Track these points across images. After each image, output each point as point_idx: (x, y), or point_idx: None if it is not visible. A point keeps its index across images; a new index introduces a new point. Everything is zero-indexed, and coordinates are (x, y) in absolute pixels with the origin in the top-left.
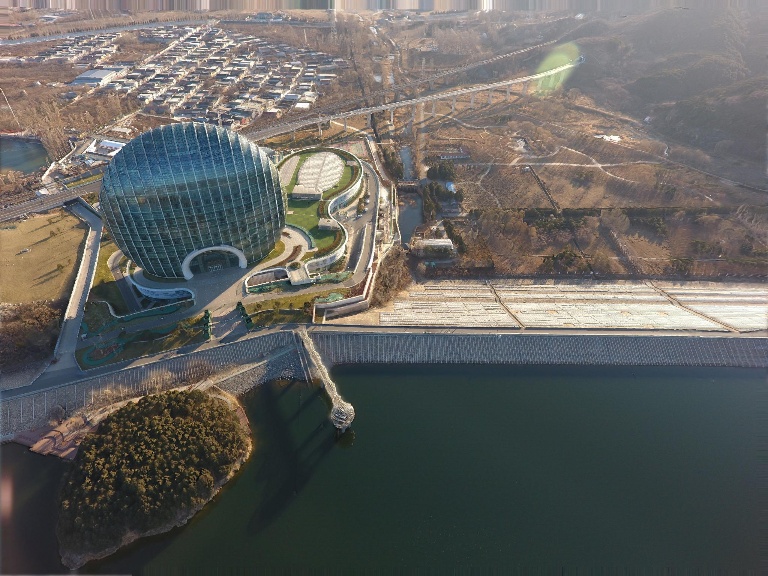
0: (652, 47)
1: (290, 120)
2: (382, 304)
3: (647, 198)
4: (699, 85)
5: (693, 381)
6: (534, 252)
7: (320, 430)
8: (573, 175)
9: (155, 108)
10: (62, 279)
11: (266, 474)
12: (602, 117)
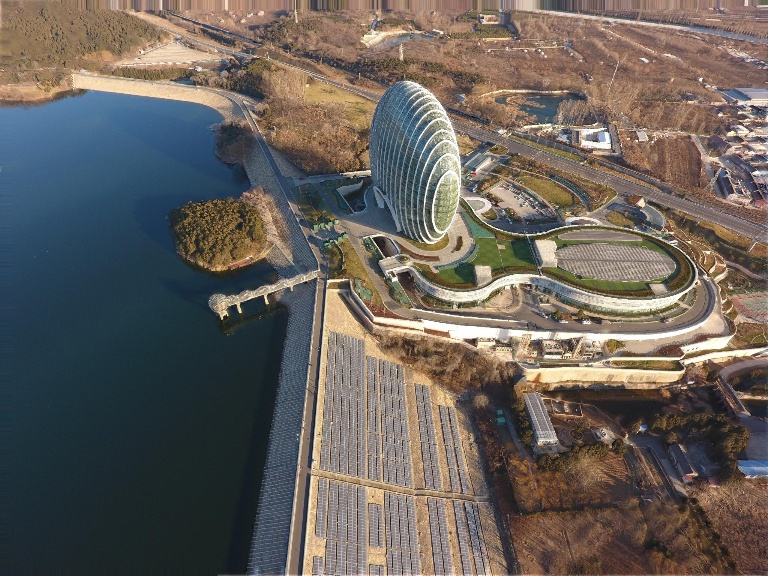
0: None
1: None
2: (390, 351)
3: None
4: None
5: None
6: None
7: None
8: None
9: (716, 140)
10: None
11: (198, 280)
12: None
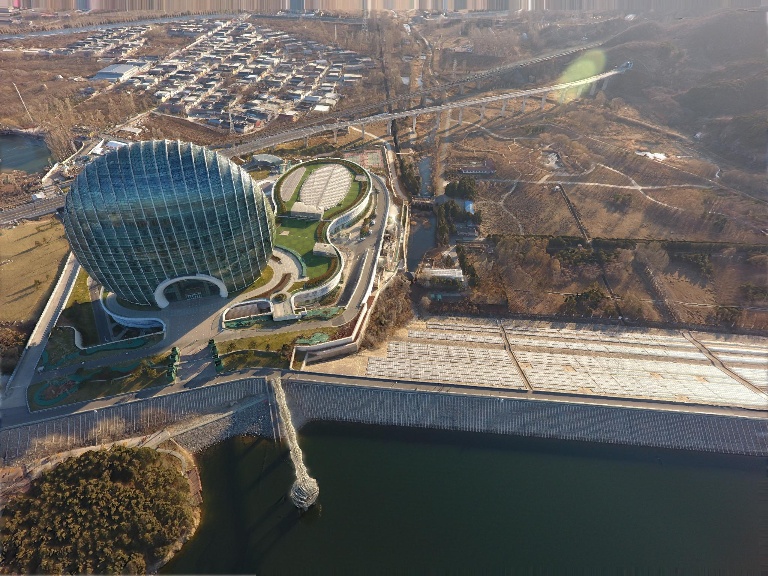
0: (709, 53)
1: (305, 124)
2: (375, 345)
3: (692, 229)
4: (761, 98)
5: (733, 474)
6: (555, 288)
7: (280, 505)
8: (608, 198)
9: (170, 107)
10: (36, 297)
11: (210, 558)
12: (647, 131)
